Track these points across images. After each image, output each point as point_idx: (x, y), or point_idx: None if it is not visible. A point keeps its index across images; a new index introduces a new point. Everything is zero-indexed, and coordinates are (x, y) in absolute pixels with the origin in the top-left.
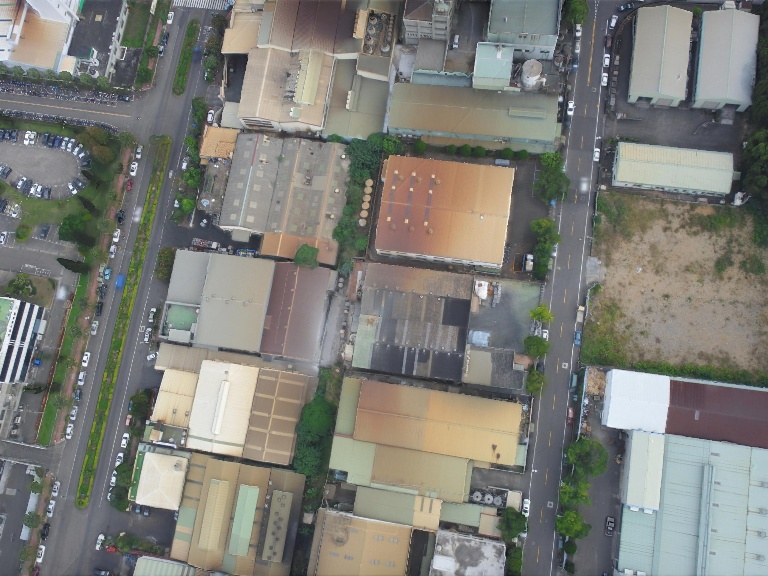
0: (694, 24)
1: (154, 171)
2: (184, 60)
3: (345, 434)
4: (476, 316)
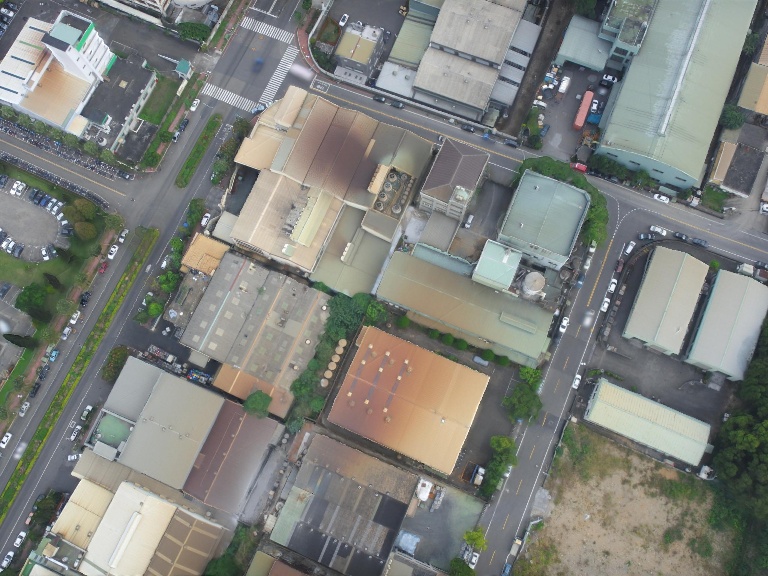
0: (708, 275)
1: (132, 261)
2: (196, 153)
3: None
4: None
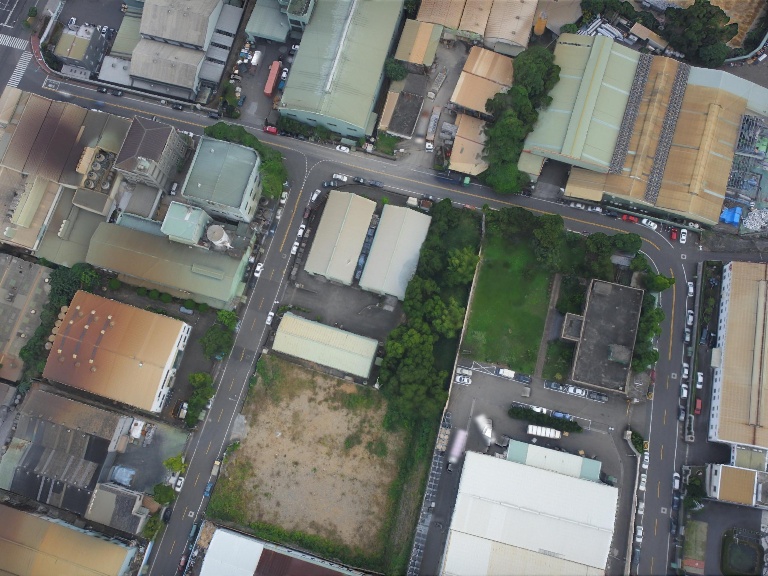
0: None
1: None
2: None
3: None
4: (127, 453)
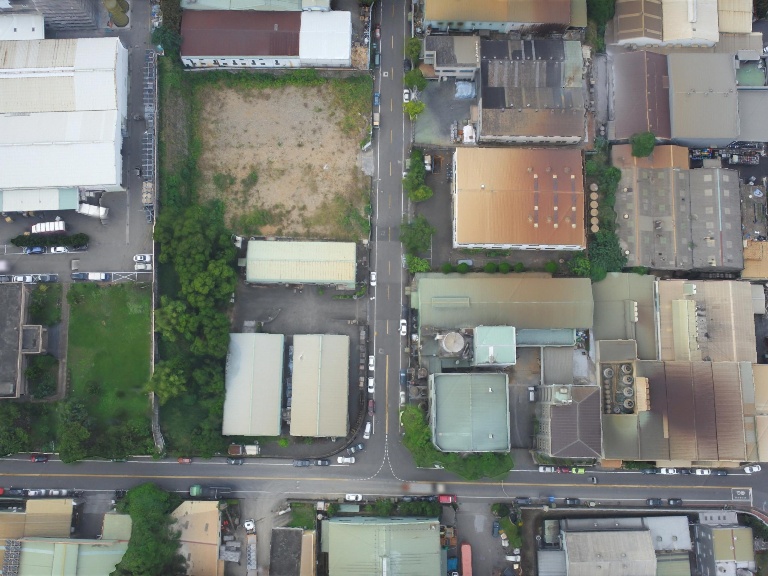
0: (285, 431)
1: None
2: None
3: None
4: None
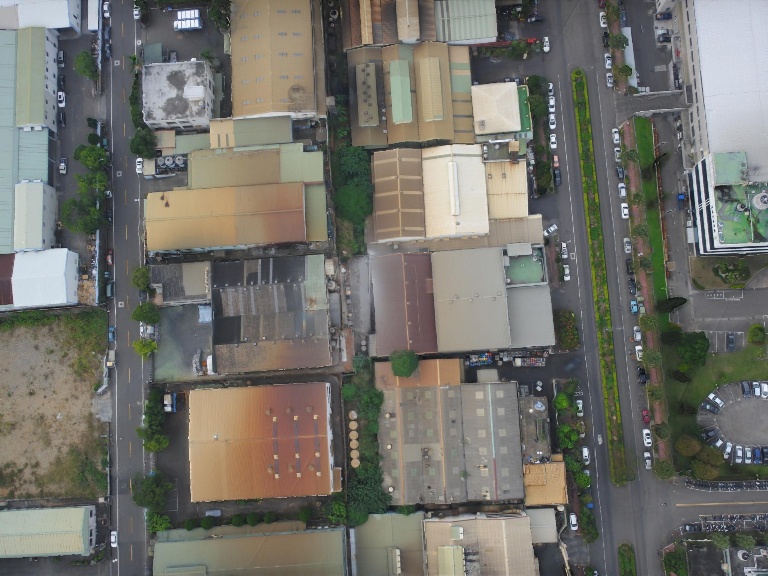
0: None
1: (621, 439)
2: None
3: (314, 186)
4: None
